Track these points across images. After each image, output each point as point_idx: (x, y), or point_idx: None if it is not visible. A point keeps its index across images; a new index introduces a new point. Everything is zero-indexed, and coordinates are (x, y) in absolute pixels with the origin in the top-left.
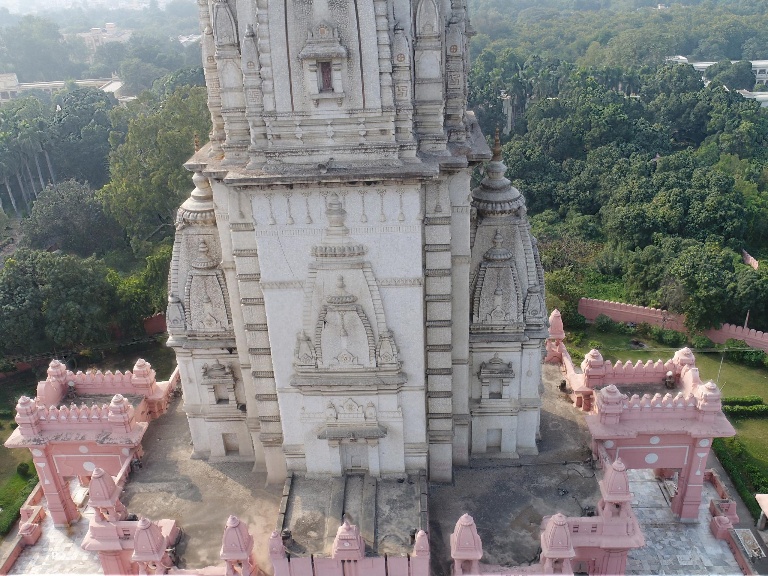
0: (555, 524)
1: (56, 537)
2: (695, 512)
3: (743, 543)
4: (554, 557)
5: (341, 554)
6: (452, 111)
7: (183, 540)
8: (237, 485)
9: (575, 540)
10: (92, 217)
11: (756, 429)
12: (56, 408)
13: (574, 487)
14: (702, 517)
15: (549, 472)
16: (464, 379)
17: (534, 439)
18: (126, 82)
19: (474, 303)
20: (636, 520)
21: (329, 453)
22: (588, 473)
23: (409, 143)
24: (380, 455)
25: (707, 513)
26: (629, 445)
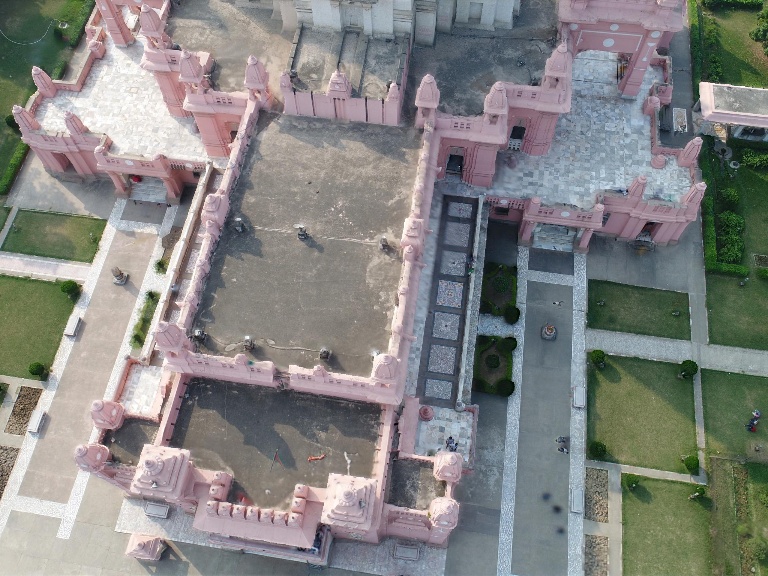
0: (495, 89)
1: (118, 54)
2: (635, 91)
3: (674, 120)
4: (491, 113)
5: (333, 93)
6: None
7: (217, 69)
8: (258, 29)
9: (517, 102)
10: None
11: (740, 22)
12: None
13: (531, 61)
14: (641, 95)
15: (515, 46)
16: None
17: (510, 15)
18: None
19: None
20: (571, 92)
21: (331, 11)
22: (547, 50)
23: None
24: (373, 17)
25: (647, 93)
26: (592, 29)
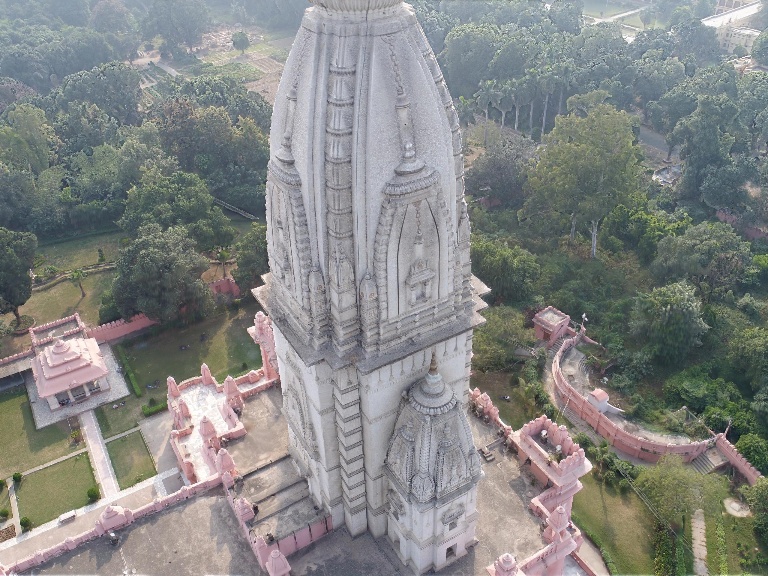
0: None
1: None
2: None
3: None
4: None
5: None
6: (365, 329)
7: (240, 440)
8: None
9: None
10: (514, 177)
11: None
12: (269, 327)
13: None
14: None
15: None
16: (372, 487)
17: (419, 565)
18: (762, 10)
19: (389, 449)
20: None
21: None
22: None
23: (314, 335)
24: None
25: None
26: None
